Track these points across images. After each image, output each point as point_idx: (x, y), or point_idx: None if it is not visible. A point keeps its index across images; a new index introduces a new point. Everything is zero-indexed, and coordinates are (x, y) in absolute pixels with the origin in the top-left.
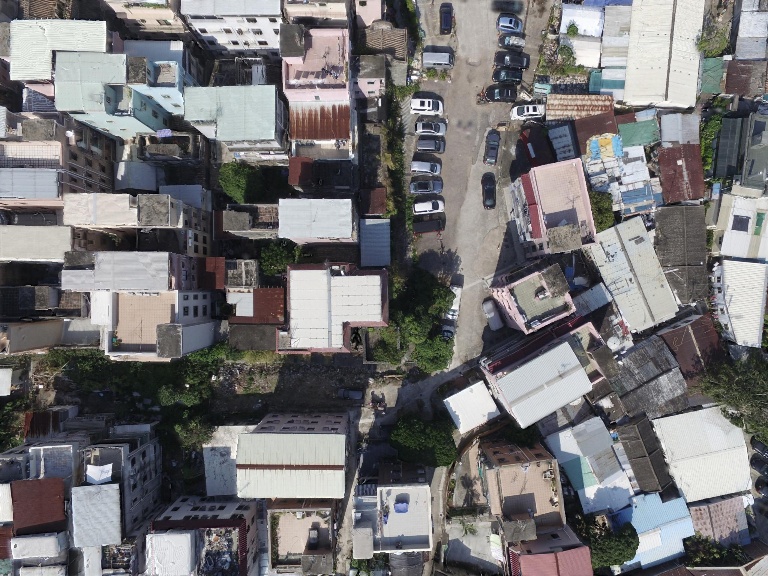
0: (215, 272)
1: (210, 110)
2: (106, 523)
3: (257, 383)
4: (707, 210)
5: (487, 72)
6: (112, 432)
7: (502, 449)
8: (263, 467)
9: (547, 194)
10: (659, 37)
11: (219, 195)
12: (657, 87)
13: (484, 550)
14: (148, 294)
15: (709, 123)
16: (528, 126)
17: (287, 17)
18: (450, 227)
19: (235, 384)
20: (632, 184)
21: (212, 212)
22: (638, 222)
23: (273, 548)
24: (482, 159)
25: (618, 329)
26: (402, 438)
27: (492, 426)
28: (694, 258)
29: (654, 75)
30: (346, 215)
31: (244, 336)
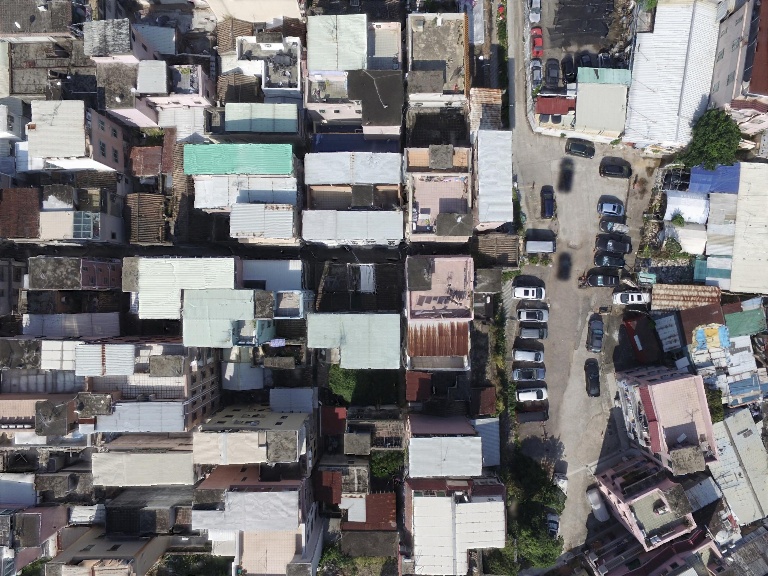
0: (332, 487)
1: (334, 338)
2: None
3: (361, 572)
4: None
5: (588, 255)
6: None
7: None
8: None
9: (666, 408)
10: (767, 229)
11: (323, 387)
12: (765, 280)
13: None
14: None
15: None
16: (631, 311)
17: (406, 236)
18: (553, 413)
19: (339, 574)
20: (739, 375)
21: (319, 408)
22: (746, 414)
23: None
24: (585, 344)
25: (727, 524)
26: None
27: None
28: None
29: (762, 267)
30: (476, 453)
31: (357, 543)
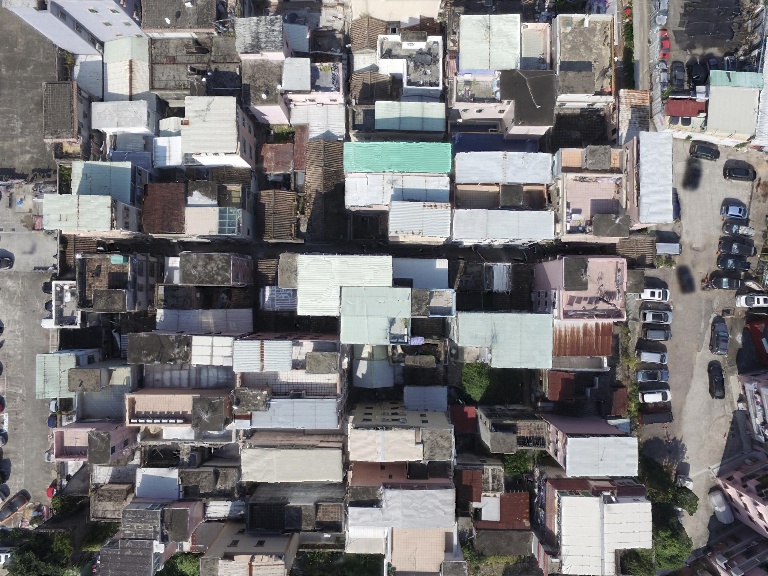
0: (472, 485)
1: (485, 337)
2: None
3: (483, 572)
4: None
5: (711, 257)
6: None
7: None
8: None
9: None
10: None
11: (450, 386)
12: None
13: None
14: None
15: None
16: None
17: None
18: (675, 415)
19: None
20: None
21: (448, 407)
22: None
23: None
24: (708, 347)
25: None
26: None
27: None
28: None
29: None
30: (633, 454)
31: (491, 542)
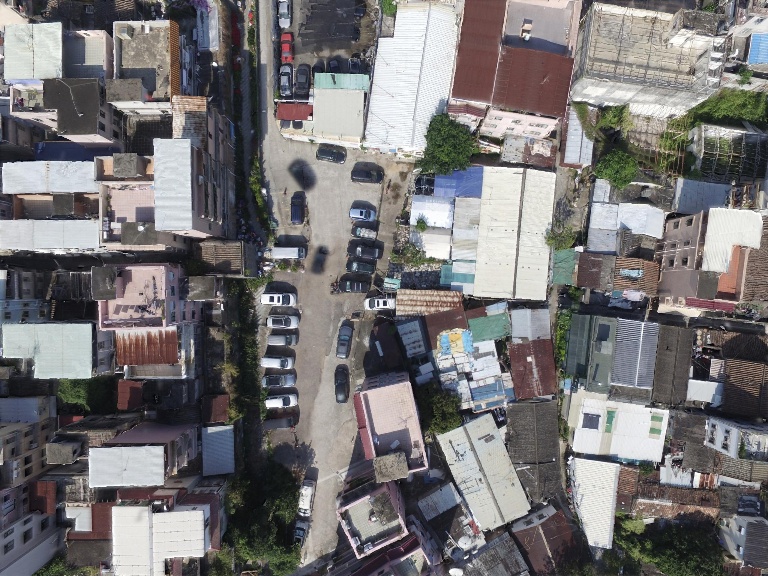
0: (46, 496)
1: (28, 347)
2: None
3: None
4: (563, 400)
5: (341, 261)
6: None
7: None
8: None
9: (379, 414)
10: (507, 233)
11: None
12: (505, 284)
13: None
14: None
15: (560, 317)
16: None
17: None
18: (304, 420)
19: None
20: (483, 380)
21: (57, 417)
22: (488, 419)
23: None
24: (335, 350)
25: (468, 530)
26: None
27: None
28: (546, 455)
29: (502, 272)
30: (158, 463)
31: (83, 552)
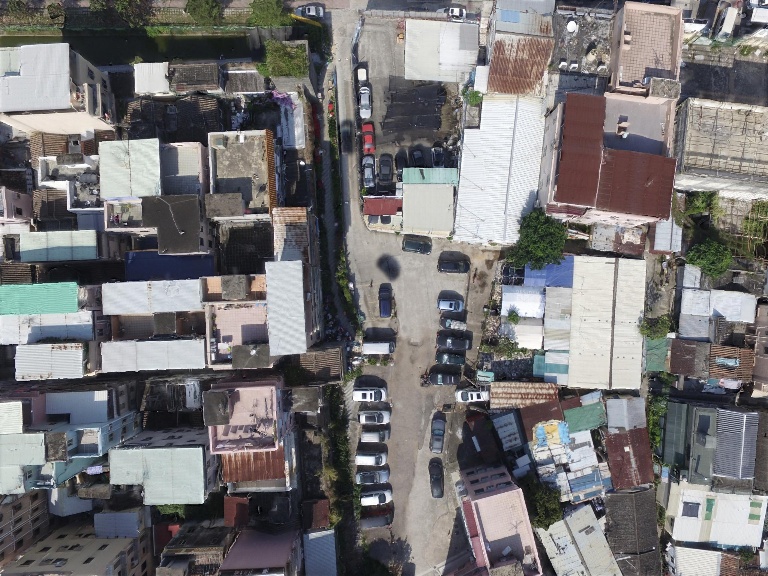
0: None
1: (136, 473)
2: None
3: None
4: (658, 485)
5: (430, 352)
6: None
7: None
8: None
9: (490, 521)
10: (600, 323)
11: None
12: (600, 375)
13: None
14: None
15: (655, 404)
16: (474, 407)
17: None
18: (399, 515)
19: None
20: (580, 471)
21: (152, 527)
22: (588, 511)
23: None
24: (428, 444)
25: None
26: None
27: None
28: (646, 544)
29: (597, 362)
30: None
31: None
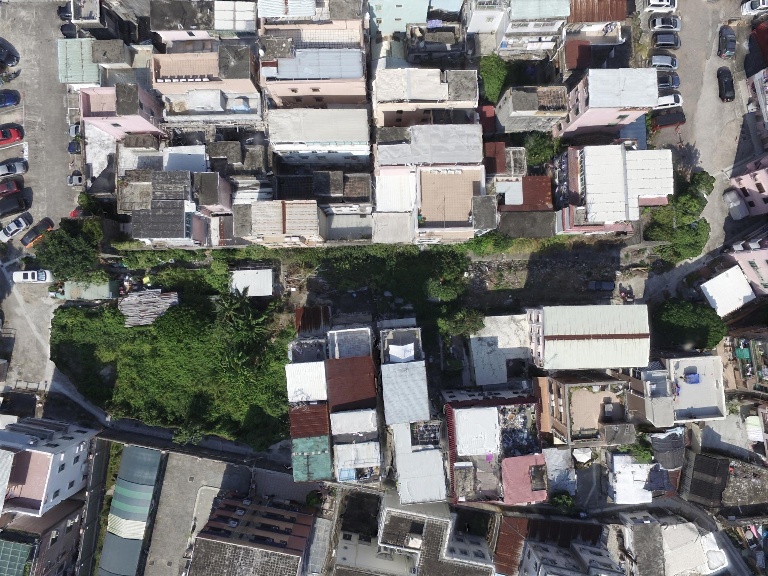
0: (495, 157)
1: None
2: (414, 400)
3: (507, 279)
4: None
5: None
6: (380, 326)
7: (761, 330)
8: (571, 337)
9: None
10: None
11: None
12: None
13: (734, 436)
14: (453, 171)
15: None
16: (759, 21)
17: None
18: (688, 121)
19: (486, 280)
20: None
21: None
22: None
23: (571, 422)
24: (716, 54)
25: None
26: (675, 318)
27: (735, 315)
28: None
29: None
30: (653, 84)
31: (515, 223)
